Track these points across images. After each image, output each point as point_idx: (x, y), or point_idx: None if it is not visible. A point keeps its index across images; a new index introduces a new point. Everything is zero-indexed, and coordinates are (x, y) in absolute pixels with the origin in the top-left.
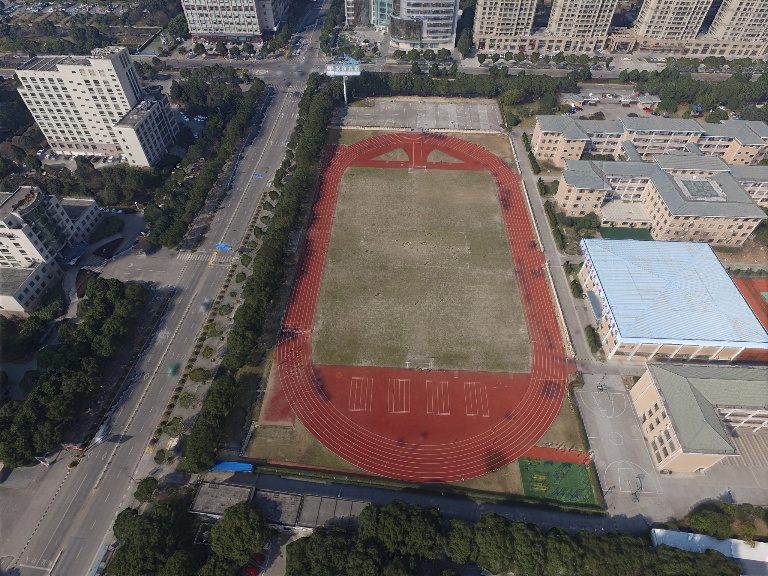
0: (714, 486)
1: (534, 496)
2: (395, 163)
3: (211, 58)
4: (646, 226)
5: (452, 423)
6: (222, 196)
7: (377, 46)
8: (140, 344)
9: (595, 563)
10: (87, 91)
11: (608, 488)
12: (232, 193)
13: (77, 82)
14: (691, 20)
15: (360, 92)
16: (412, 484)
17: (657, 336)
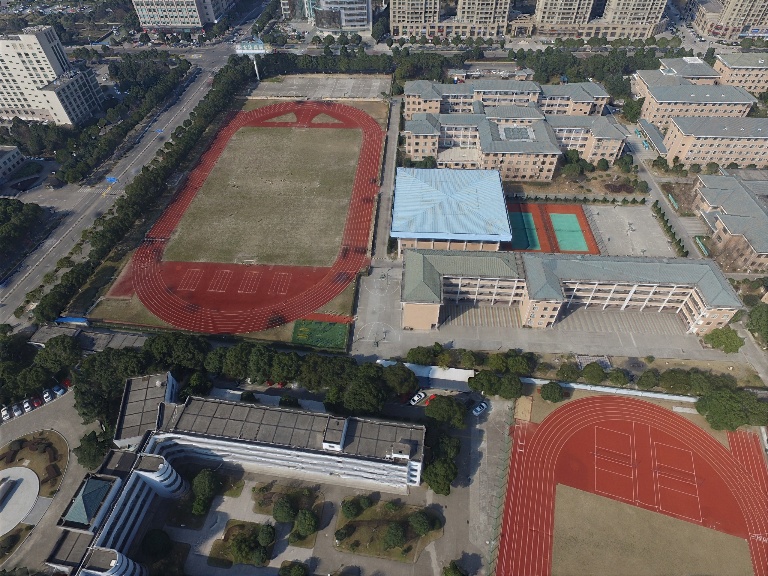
0: (442, 338)
1: (298, 343)
2: (283, 124)
3: (156, 46)
4: (475, 167)
5: (255, 298)
6: (129, 148)
7: (304, 35)
8: (30, 247)
9: (305, 368)
10: (20, 62)
11: (358, 338)
12: (138, 146)
13: (12, 55)
14: (580, 6)
15: (272, 70)
16: (205, 333)
17: (420, 231)
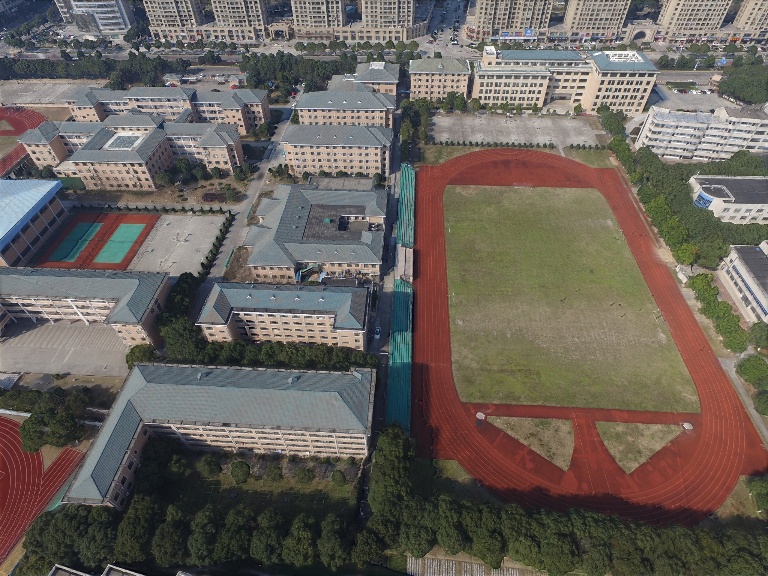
0: None
1: None
2: None
3: None
4: None
5: None
6: None
7: (69, 39)
8: None
9: None
10: None
11: None
12: None
13: None
14: (330, 9)
15: None
16: None
17: None
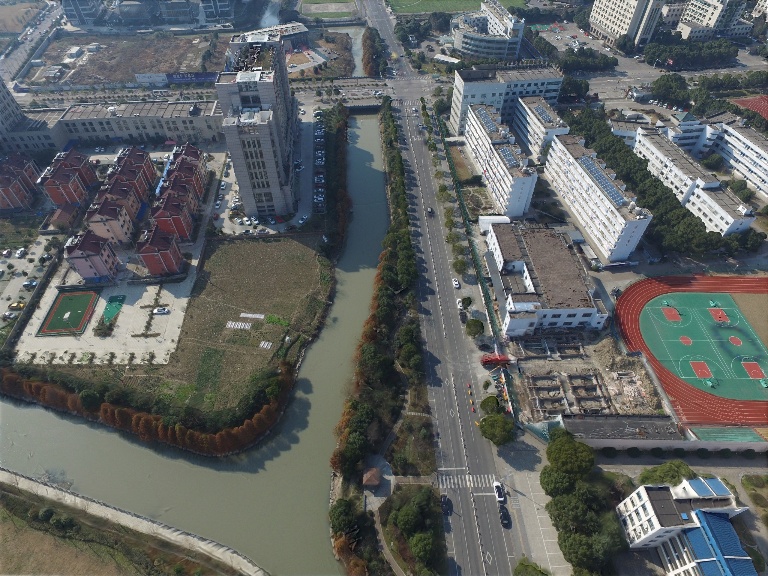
0: None
1: None
2: None
3: None
4: None
5: None
6: None
7: None
8: (713, 67)
9: None
10: None
11: None
12: None
13: None
14: None
15: None
16: None
17: None
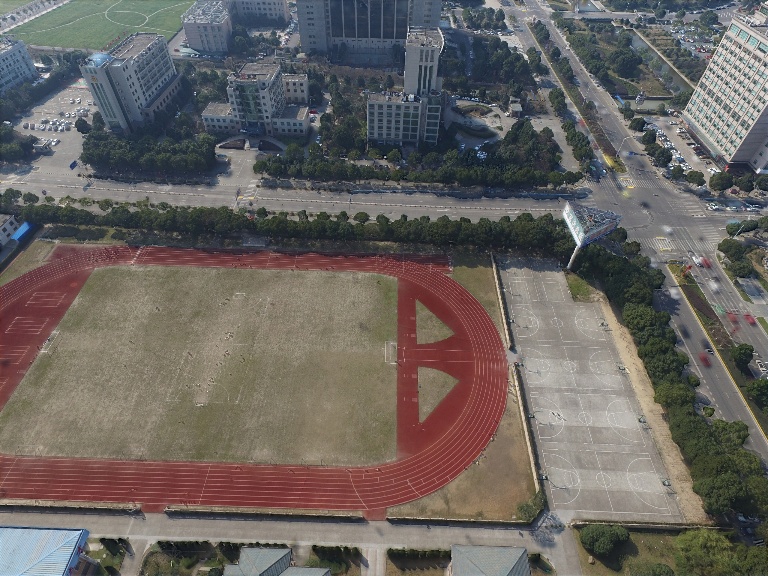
0: None
1: None
2: (410, 327)
3: None
4: None
5: None
6: (338, 190)
7: None
8: (162, 180)
9: None
10: None
11: None
12: (343, 195)
13: None
14: None
15: (597, 276)
16: None
17: None
